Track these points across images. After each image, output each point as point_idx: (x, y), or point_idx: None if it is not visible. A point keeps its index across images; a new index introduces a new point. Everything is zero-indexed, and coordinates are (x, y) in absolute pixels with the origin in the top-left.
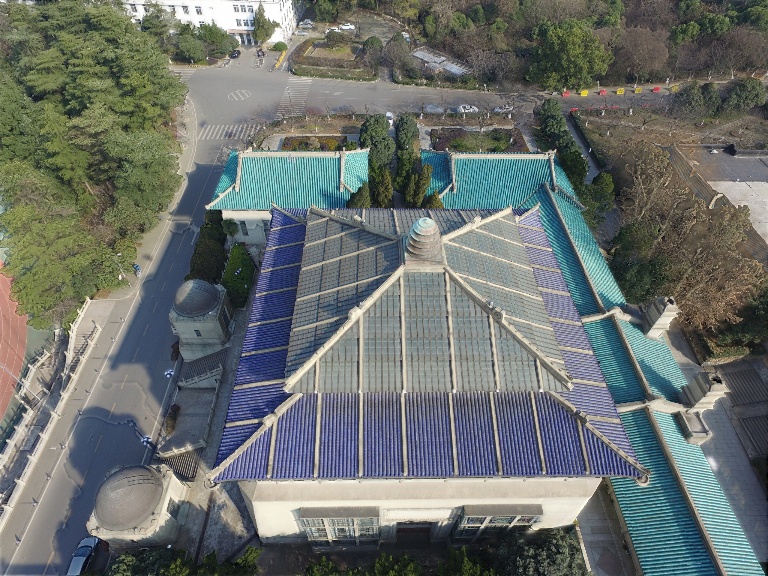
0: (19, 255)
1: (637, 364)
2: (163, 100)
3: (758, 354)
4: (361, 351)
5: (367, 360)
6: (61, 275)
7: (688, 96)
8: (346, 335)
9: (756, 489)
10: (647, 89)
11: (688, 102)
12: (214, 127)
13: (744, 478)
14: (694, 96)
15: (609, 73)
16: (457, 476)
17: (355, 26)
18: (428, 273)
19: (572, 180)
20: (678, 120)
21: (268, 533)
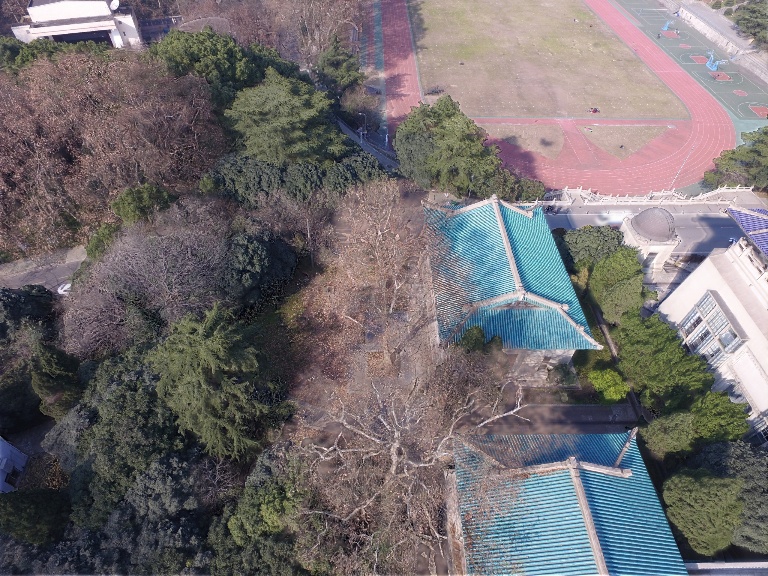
0: (767, 130)
1: None
2: None
3: None
4: None
5: None
6: (766, 159)
7: None
8: None
9: None
10: None
11: None
12: None
13: None
14: None
15: None
16: None
17: None
18: None
19: None
20: None
21: (666, 307)
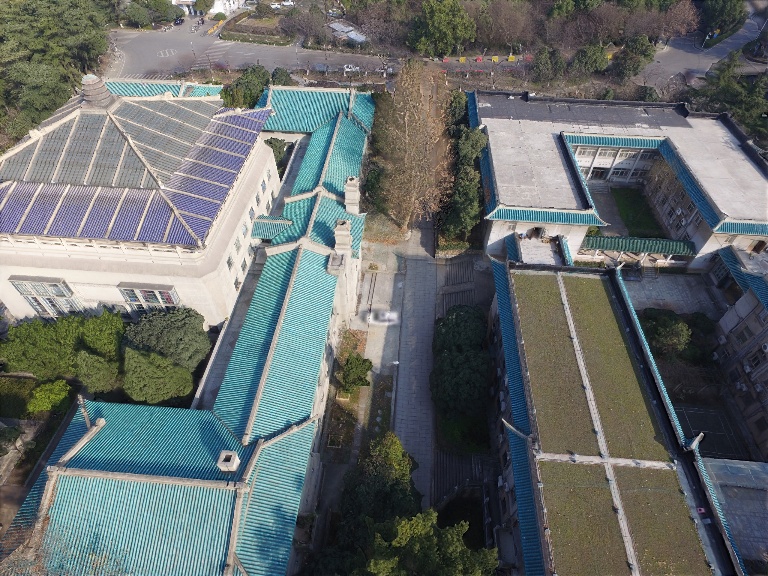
0: None
1: (311, 220)
2: (68, 42)
3: (477, 249)
4: (33, 157)
5: (36, 162)
6: None
7: (537, 60)
8: (28, 148)
9: (429, 339)
10: (521, 58)
11: (536, 66)
12: (133, 76)
13: (423, 332)
14: (542, 60)
15: (479, 41)
16: (79, 237)
17: (297, 3)
18: (97, 115)
19: (379, 115)
20: (530, 82)
21: (17, 313)
